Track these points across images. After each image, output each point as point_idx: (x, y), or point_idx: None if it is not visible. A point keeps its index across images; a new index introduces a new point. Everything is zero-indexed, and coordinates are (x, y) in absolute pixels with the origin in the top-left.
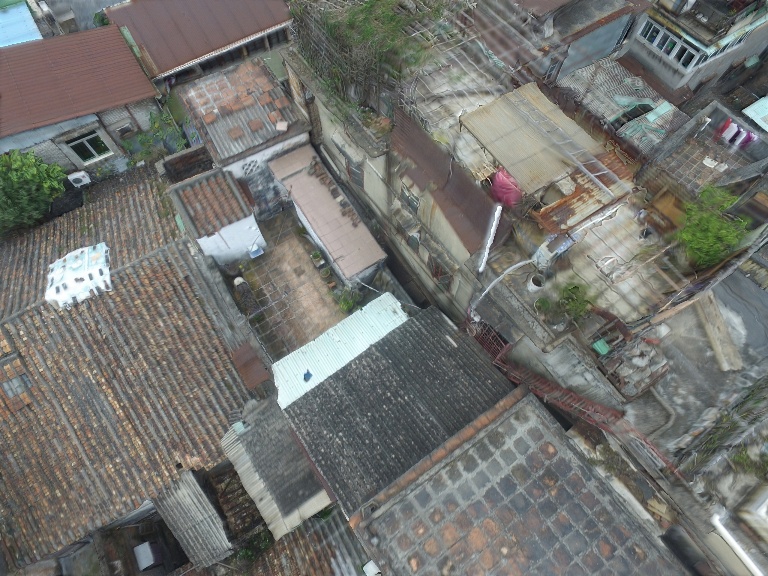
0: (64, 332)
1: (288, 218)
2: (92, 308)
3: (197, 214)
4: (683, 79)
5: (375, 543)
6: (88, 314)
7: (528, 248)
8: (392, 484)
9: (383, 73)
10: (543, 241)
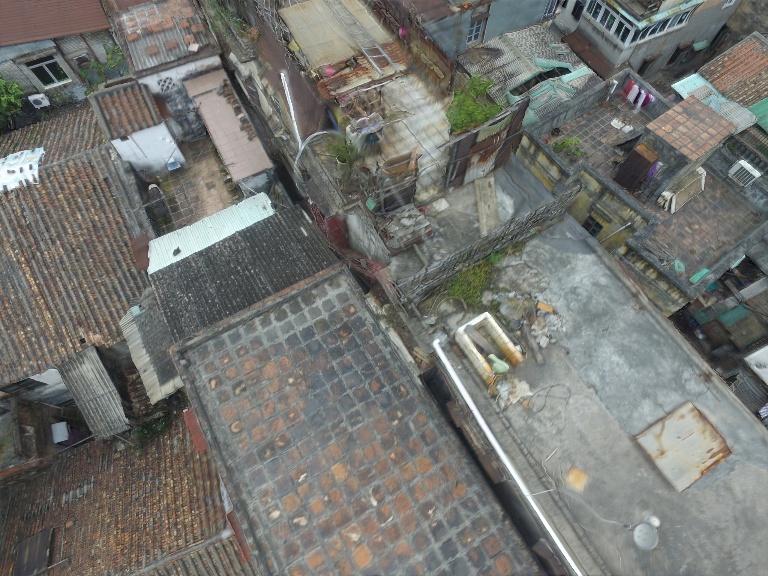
0: None
1: (210, 141)
2: (20, 197)
3: (112, 119)
4: (622, 55)
5: (182, 363)
6: (16, 201)
7: None
8: (212, 325)
9: None
10: None
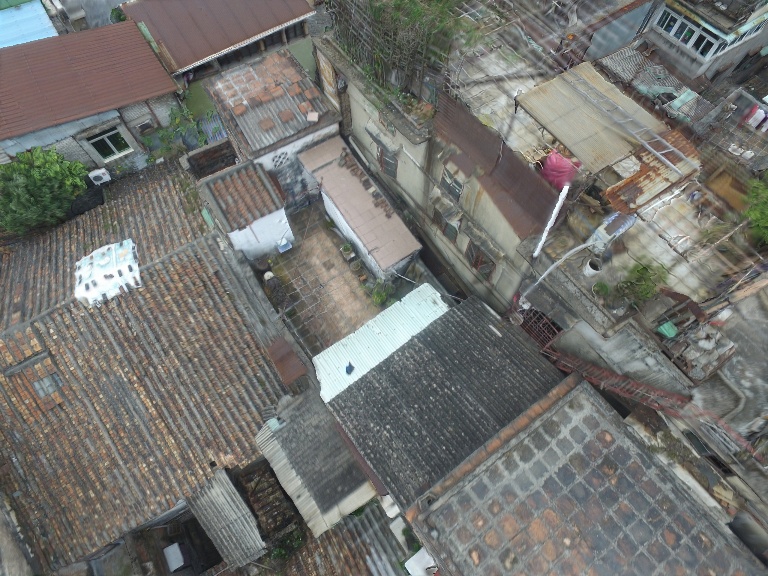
0: (94, 330)
1: (315, 212)
2: (122, 305)
3: (228, 207)
4: (701, 68)
5: (435, 536)
6: (118, 311)
7: (581, 232)
8: (448, 476)
9: (429, 56)
10: (595, 225)
